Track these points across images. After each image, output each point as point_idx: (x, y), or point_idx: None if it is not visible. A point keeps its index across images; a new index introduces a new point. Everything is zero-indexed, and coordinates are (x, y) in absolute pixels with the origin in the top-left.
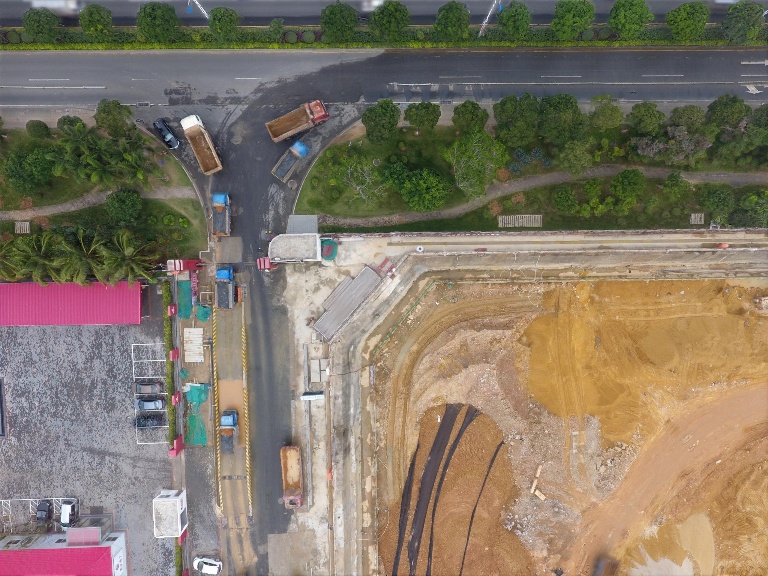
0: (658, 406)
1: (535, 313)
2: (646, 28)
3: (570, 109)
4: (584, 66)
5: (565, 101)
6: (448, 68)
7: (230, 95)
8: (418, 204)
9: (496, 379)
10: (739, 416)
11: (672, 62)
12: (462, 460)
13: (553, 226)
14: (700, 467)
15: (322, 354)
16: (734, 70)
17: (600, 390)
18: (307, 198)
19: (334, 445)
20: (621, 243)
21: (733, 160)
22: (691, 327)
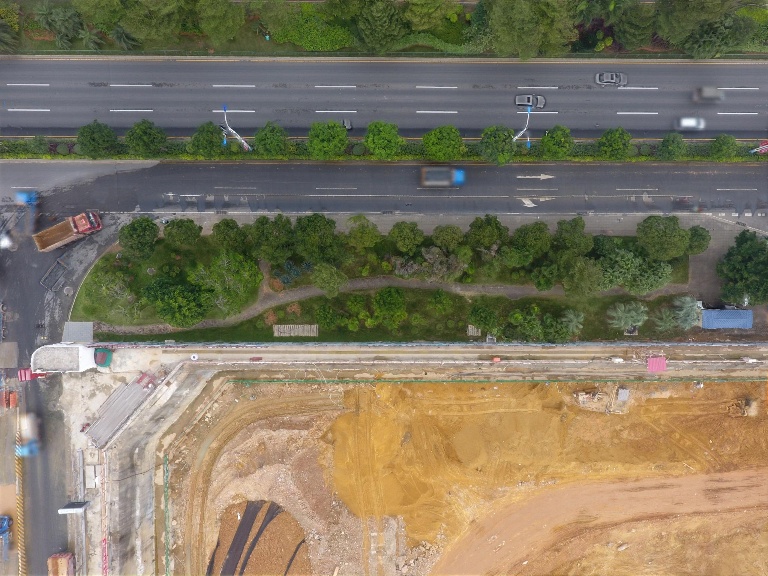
0: (463, 506)
1: (335, 412)
2: (418, 143)
3: (319, 232)
4: (359, 178)
5: (314, 224)
6: (223, 179)
7: (6, 203)
8: (172, 321)
9: (292, 479)
10: (547, 516)
11: (447, 175)
12: (260, 559)
13: (328, 336)
14: (506, 568)
15: (98, 460)
16: (509, 184)
17: (404, 489)
18: (82, 305)
19: (110, 551)
20: (397, 353)
21: (508, 273)
22: (502, 424)
